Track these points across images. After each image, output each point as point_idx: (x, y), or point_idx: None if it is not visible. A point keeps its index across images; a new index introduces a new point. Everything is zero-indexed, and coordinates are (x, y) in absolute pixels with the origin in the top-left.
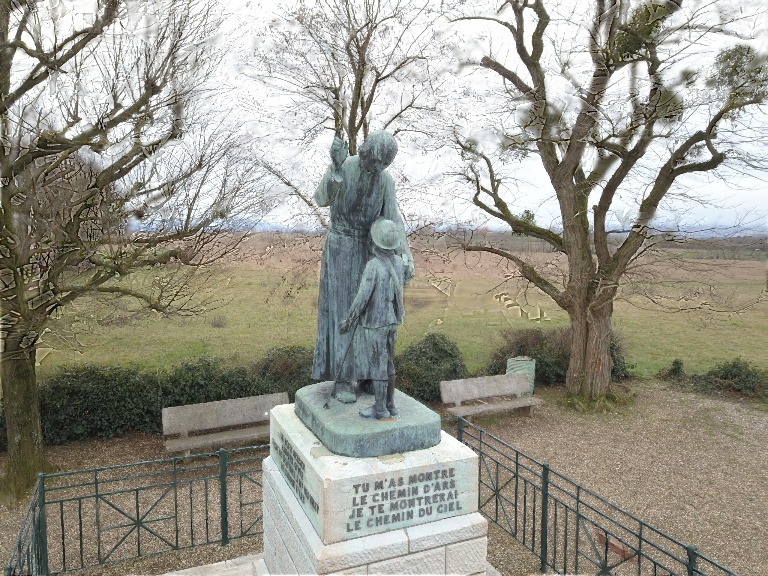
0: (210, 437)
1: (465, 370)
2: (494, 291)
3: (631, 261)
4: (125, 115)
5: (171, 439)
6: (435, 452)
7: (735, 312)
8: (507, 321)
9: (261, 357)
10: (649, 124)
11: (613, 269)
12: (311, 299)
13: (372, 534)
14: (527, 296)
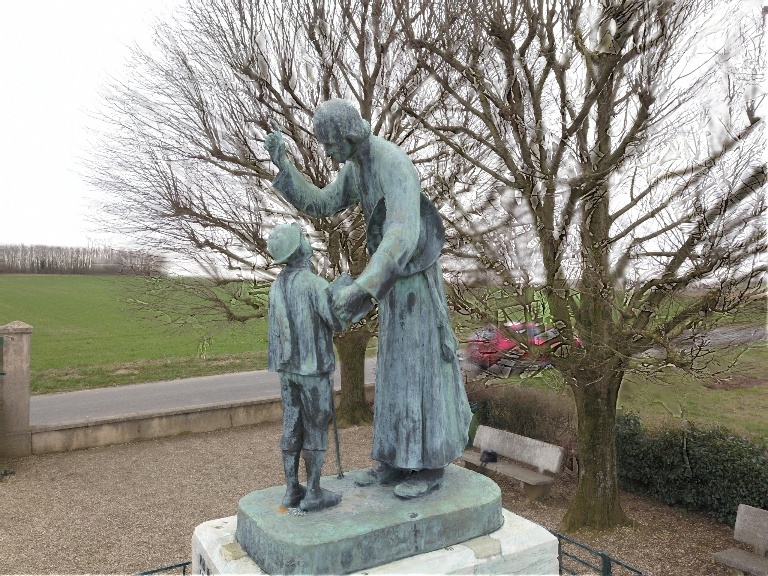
0: None
1: None
2: None
3: None
4: (627, 139)
5: (740, 548)
6: None
7: None
8: None
9: None
10: None
11: None
12: None
13: None
14: None
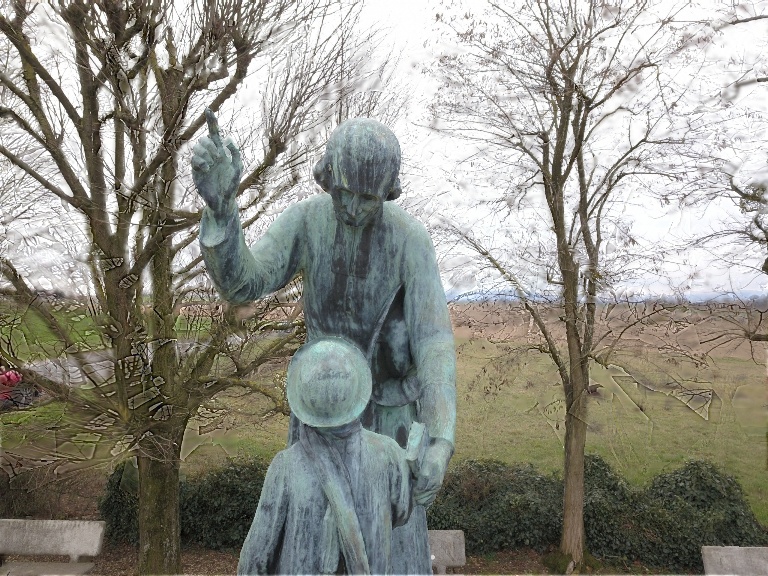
0: None
1: (753, 523)
2: None
3: None
4: (249, 180)
5: None
6: None
7: None
8: None
9: None
10: None
11: None
12: (517, 398)
13: None
14: None
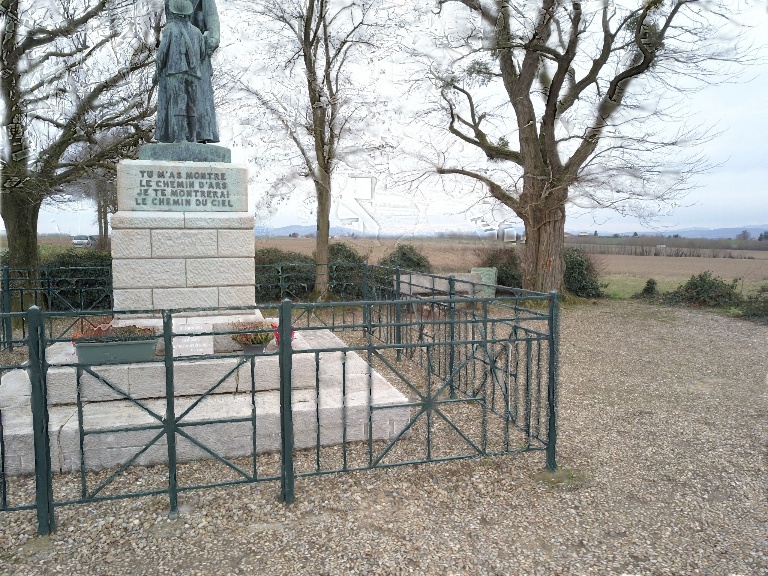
0: None
1: None
2: (467, 212)
3: (582, 169)
4: (92, 12)
5: None
6: (211, 162)
7: (661, 199)
8: (481, 241)
9: None
10: (574, 24)
11: (563, 176)
12: (290, 210)
13: (157, 211)
14: (494, 212)
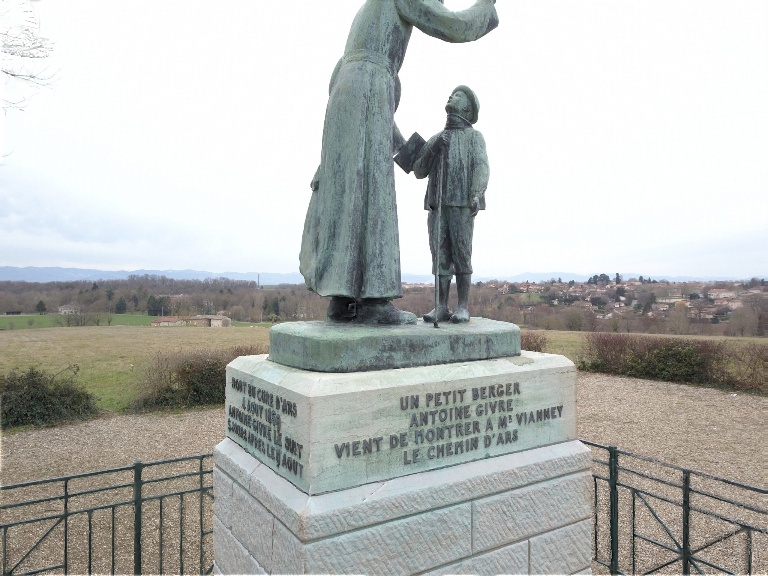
0: None
1: None
2: None
3: None
4: None
5: None
6: None
7: None
8: None
9: None
10: None
11: None
12: None
13: None
14: None
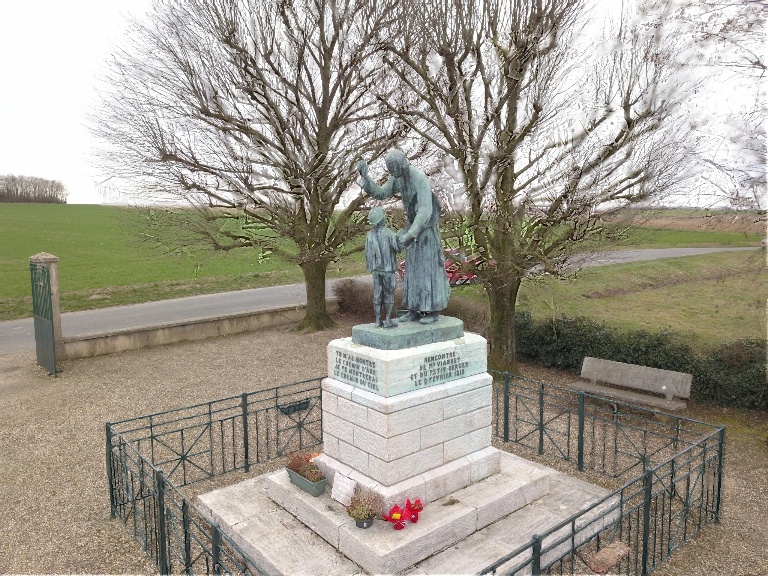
0: (604, 389)
1: None
2: None
3: None
4: (526, 131)
5: (584, 381)
6: (372, 350)
7: None
8: None
9: (721, 342)
10: None
11: None
12: None
13: (343, 382)
14: None
